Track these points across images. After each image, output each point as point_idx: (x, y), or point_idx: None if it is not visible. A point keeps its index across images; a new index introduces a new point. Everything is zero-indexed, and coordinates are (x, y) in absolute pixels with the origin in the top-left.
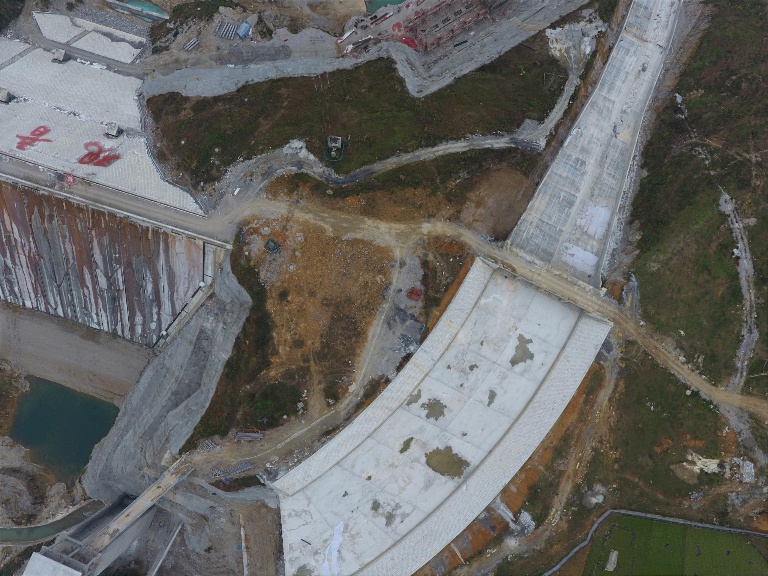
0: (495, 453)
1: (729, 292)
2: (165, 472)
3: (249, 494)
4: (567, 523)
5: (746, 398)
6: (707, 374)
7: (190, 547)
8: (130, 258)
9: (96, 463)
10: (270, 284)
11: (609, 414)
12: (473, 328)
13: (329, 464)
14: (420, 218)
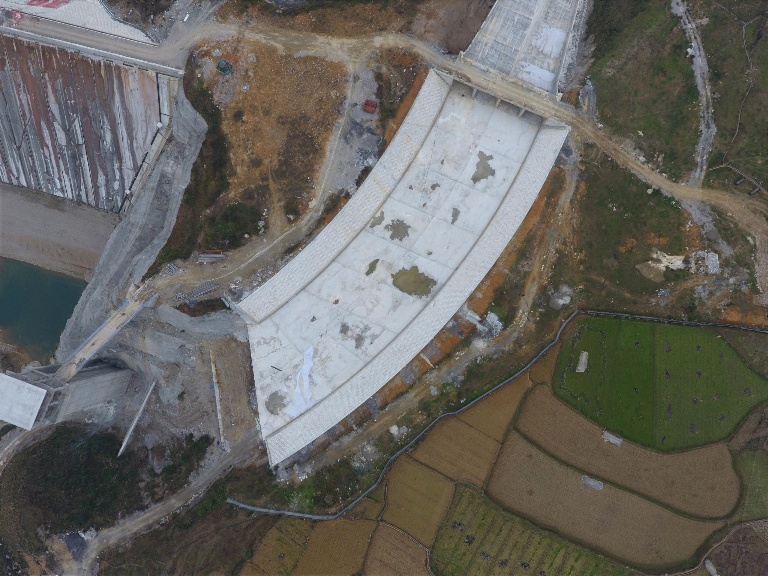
0: (461, 268)
1: (685, 90)
2: (129, 299)
3: (217, 324)
4: (535, 324)
5: (707, 191)
6: (667, 172)
7: (164, 400)
8: (86, 103)
9: (67, 330)
10: (224, 105)
11: (571, 216)
12: (433, 148)
13: (295, 288)
14: (371, 32)
